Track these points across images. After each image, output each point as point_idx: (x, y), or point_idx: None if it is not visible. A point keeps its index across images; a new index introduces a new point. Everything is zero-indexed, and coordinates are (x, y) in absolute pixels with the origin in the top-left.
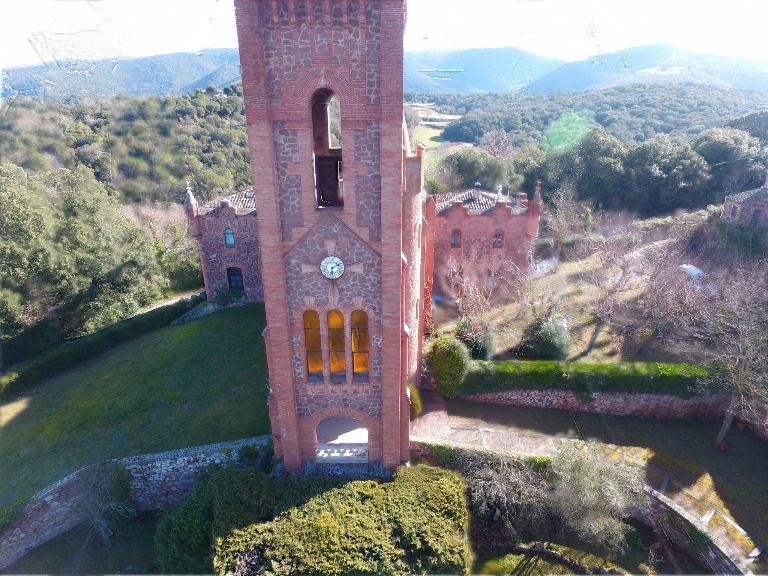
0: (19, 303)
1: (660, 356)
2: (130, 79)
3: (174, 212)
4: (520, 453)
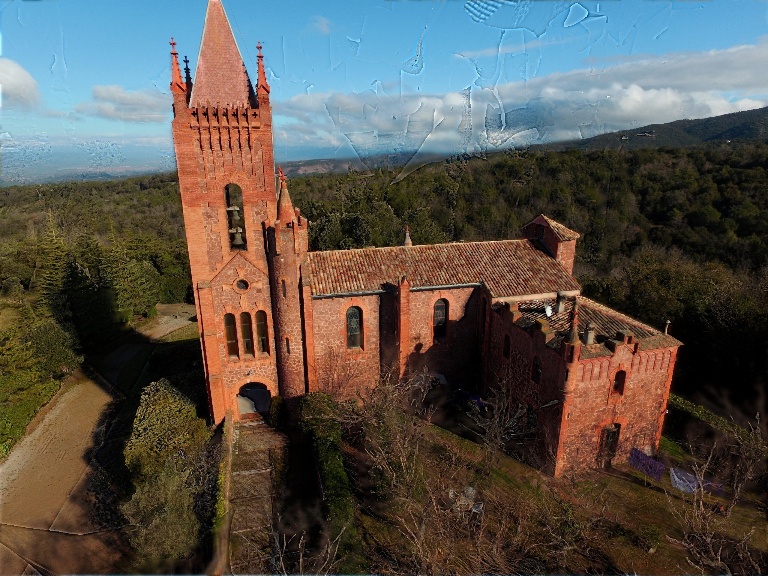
0: None
1: None
2: (559, 142)
3: None
4: (225, 481)
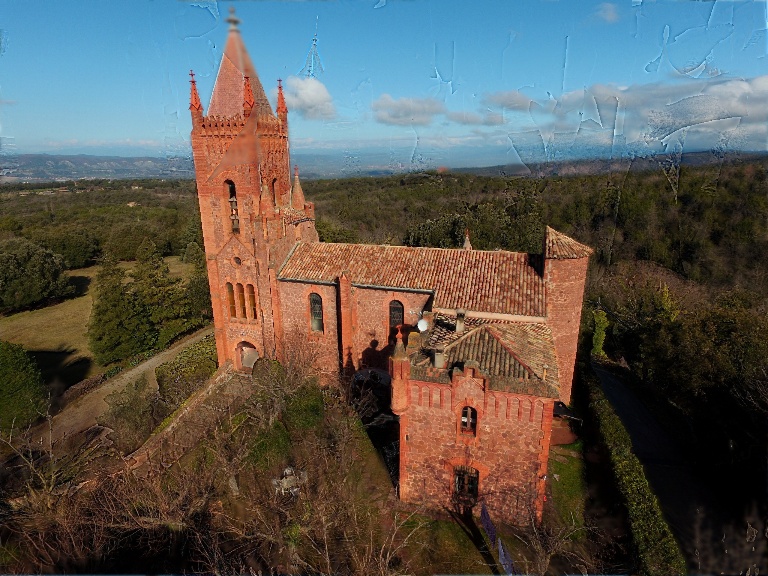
0: None
1: (169, 566)
2: (760, 138)
3: (671, 282)
4: None
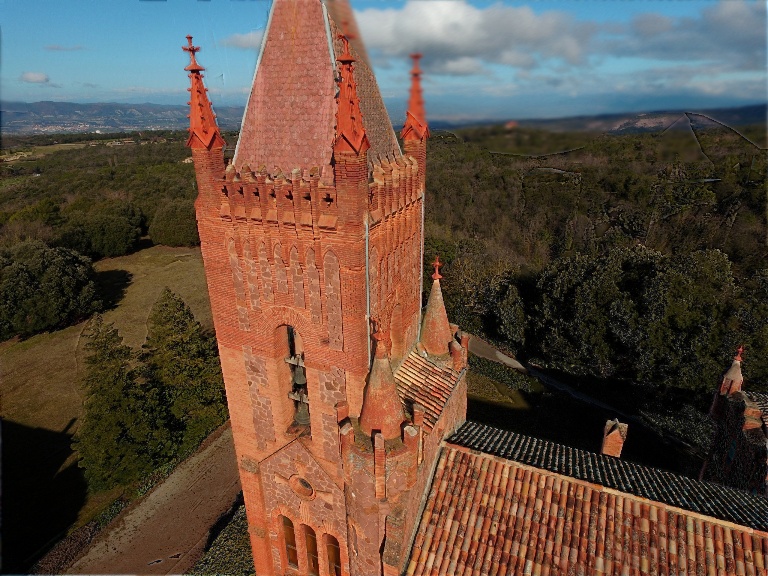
0: (605, 357)
1: None
2: None
3: None
4: None
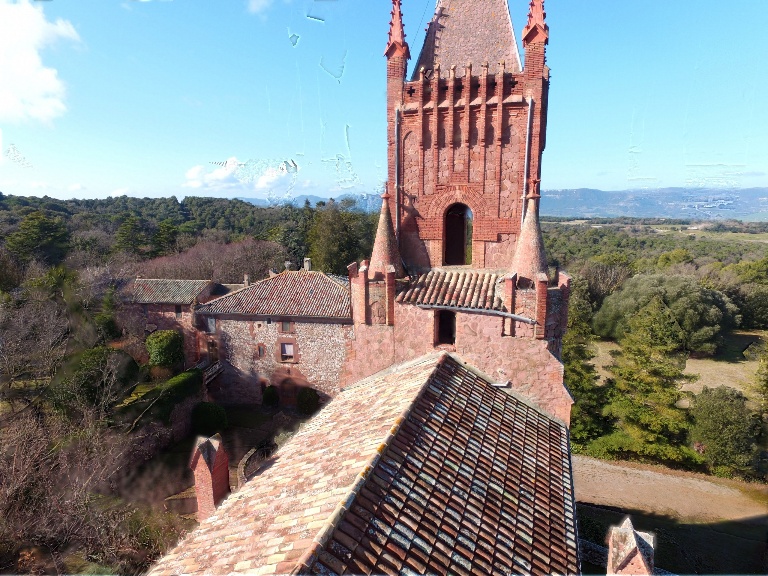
0: None
1: None
2: None
3: None
4: None
